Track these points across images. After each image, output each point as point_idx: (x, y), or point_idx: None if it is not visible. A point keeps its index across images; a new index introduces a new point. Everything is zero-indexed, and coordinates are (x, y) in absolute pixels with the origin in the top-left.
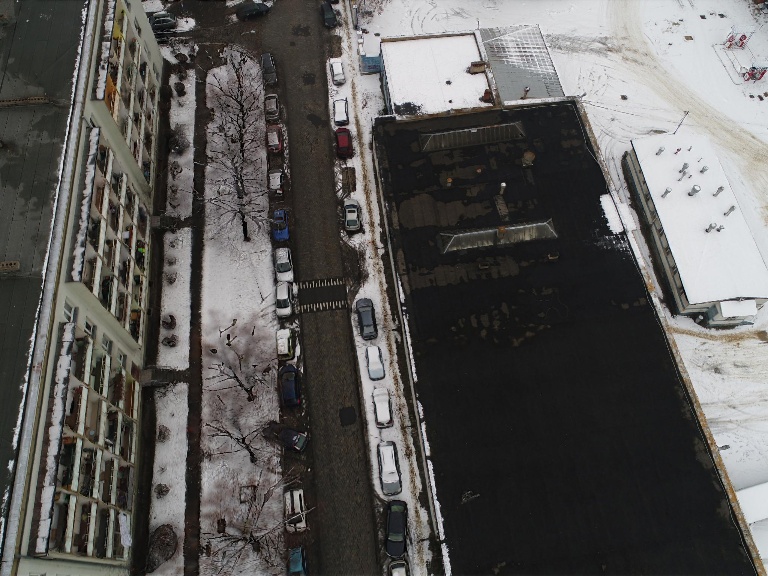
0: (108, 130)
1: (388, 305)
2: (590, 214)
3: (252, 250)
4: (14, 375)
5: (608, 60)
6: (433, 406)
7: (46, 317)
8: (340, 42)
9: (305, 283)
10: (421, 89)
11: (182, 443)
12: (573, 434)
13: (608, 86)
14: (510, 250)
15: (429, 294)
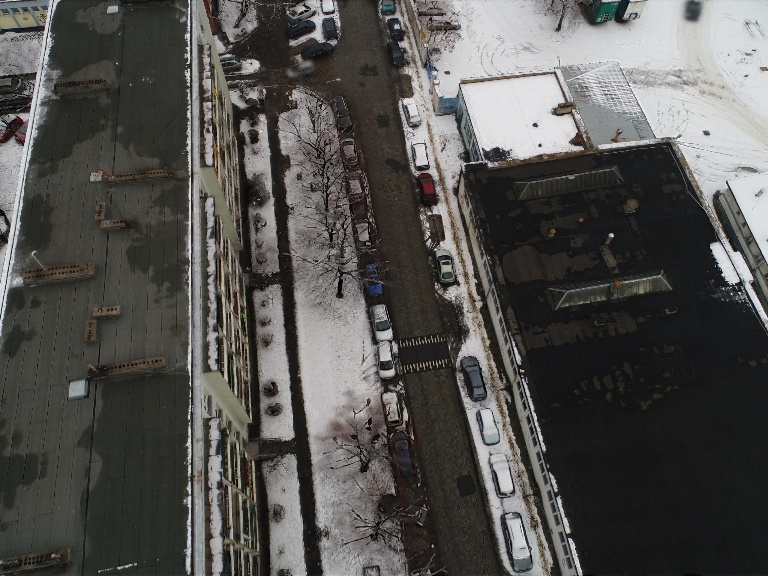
0: (212, 194)
1: (493, 362)
2: (702, 264)
3: (346, 307)
4: (175, 487)
5: (685, 94)
6: (566, 478)
7: (198, 418)
8: (410, 81)
9: (404, 341)
10: (508, 133)
11: (297, 521)
12: (718, 505)
13: (689, 121)
14: (624, 305)
15: (546, 355)
